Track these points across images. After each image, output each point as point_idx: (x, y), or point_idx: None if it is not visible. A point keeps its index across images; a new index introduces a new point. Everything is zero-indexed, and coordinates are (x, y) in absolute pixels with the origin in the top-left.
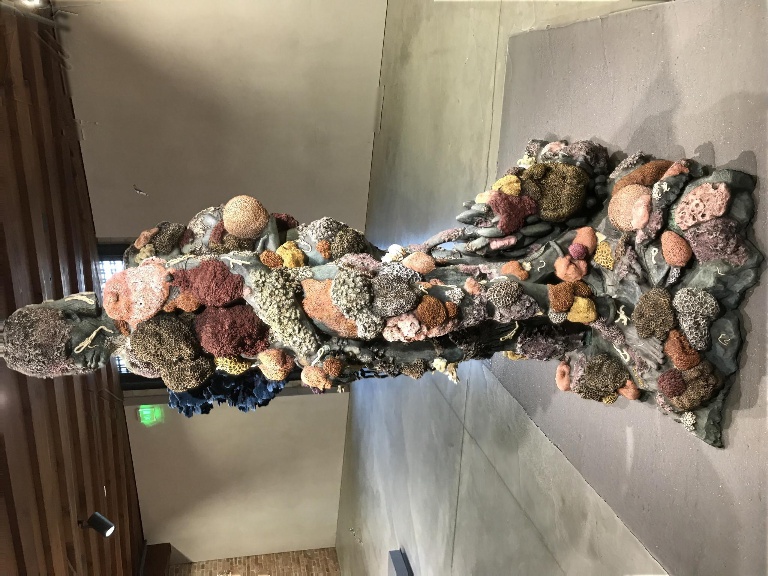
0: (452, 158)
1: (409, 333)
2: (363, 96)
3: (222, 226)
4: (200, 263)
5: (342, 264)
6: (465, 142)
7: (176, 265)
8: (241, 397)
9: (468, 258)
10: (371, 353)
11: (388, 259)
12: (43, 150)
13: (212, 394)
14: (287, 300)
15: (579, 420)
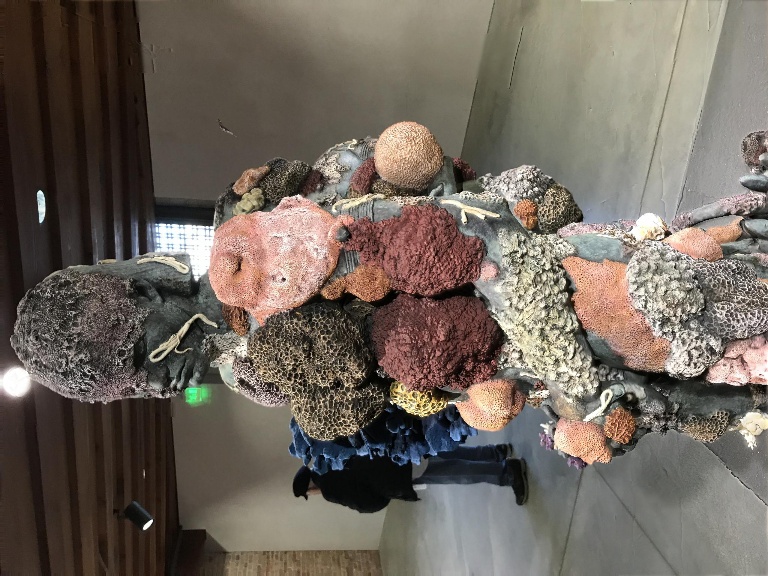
0: (595, 125)
1: (767, 373)
2: (495, 39)
3: (371, 167)
4: (402, 209)
5: (624, 235)
6: (620, 104)
7: (353, 210)
8: (400, 442)
9: (767, 244)
10: (664, 398)
11: (637, 236)
12: (105, 81)
13: (367, 442)
14: (560, 294)
15: None
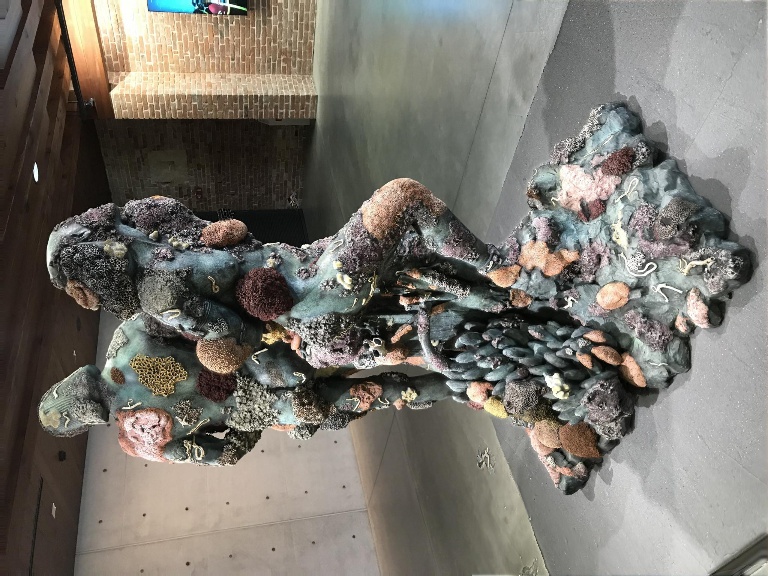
0: None
1: None
2: None
3: None
4: None
5: None
6: None
7: None
8: None
9: None
10: None
11: None
12: None
13: None
14: None
15: None
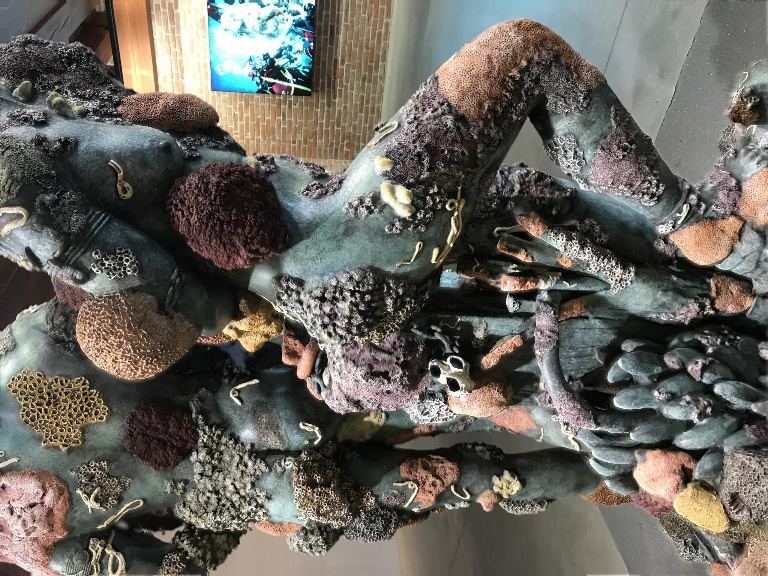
0: None
1: None
2: None
3: None
4: None
5: None
6: None
7: None
8: None
9: None
10: None
11: None
12: None
13: None
14: None
15: (692, 167)
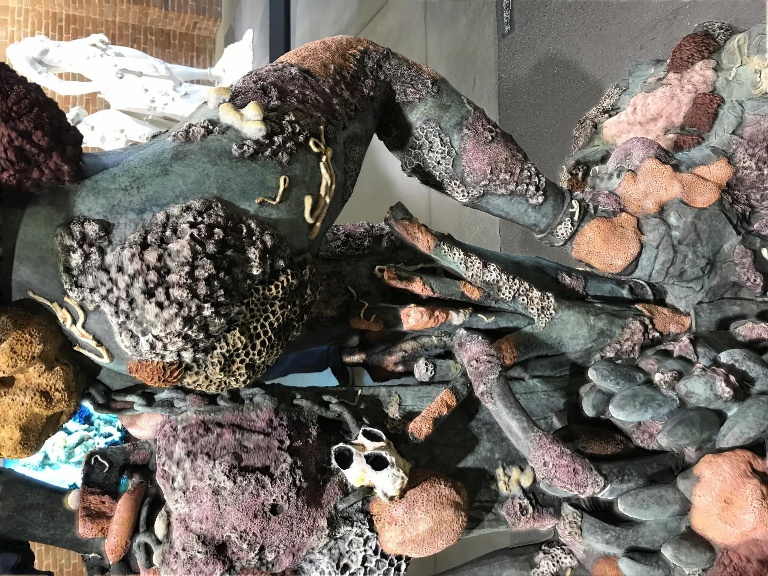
0: None
1: None
2: None
3: None
4: None
5: None
6: None
7: None
8: None
9: None
10: None
11: (349, 479)
12: None
13: None
14: None
15: None
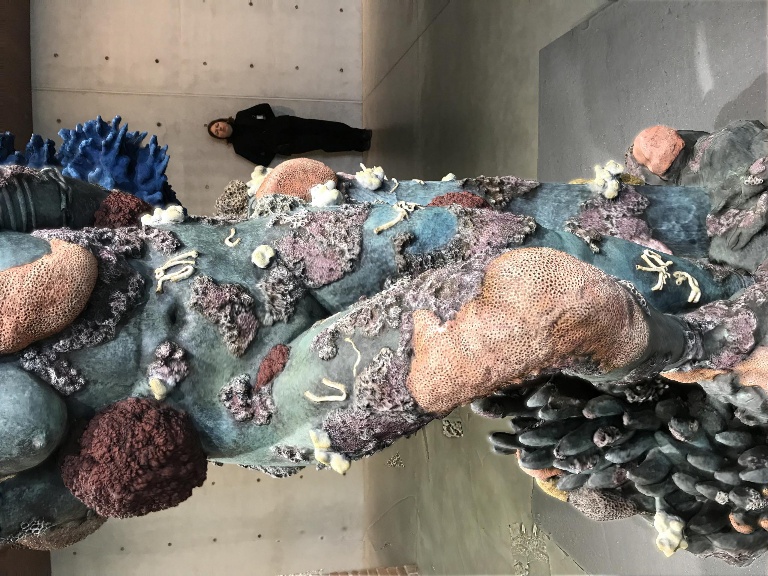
0: None
1: None
2: None
3: None
4: None
5: None
6: None
7: None
8: None
9: None
10: None
11: None
12: None
13: None
14: None
15: None
